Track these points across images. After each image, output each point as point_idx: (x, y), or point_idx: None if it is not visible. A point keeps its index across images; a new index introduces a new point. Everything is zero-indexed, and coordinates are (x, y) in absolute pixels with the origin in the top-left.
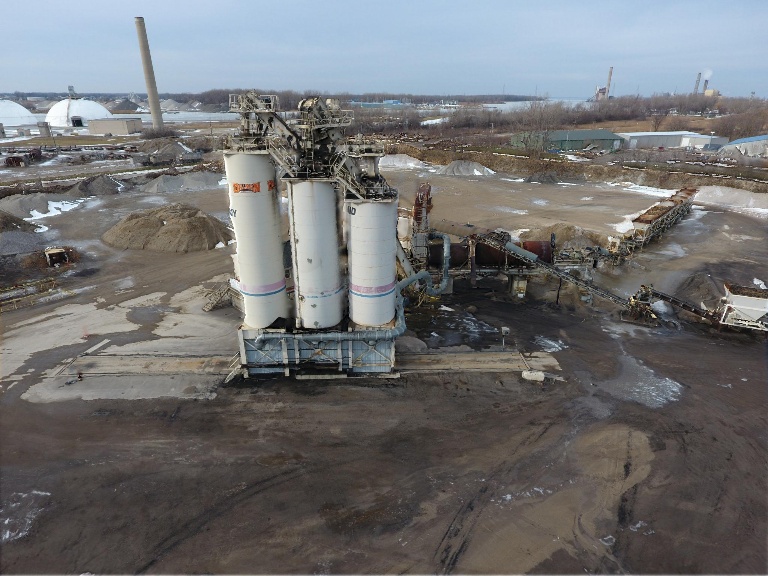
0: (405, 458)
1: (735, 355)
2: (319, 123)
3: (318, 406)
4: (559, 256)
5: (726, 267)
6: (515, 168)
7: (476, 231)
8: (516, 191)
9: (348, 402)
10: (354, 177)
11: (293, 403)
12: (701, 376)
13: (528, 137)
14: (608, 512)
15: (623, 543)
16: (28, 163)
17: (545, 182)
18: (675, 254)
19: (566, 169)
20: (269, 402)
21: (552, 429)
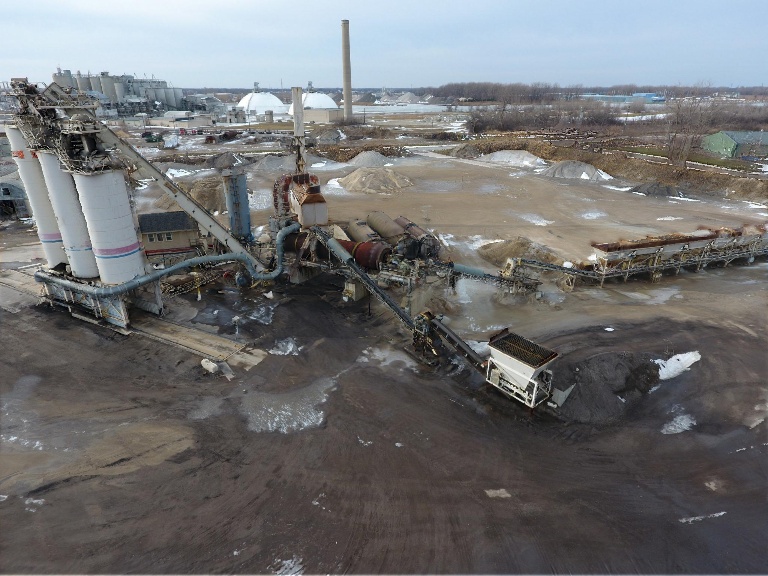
0: (21, 387)
1: (448, 419)
2: (42, 104)
3: (47, 336)
4: (385, 263)
5: (680, 328)
6: (642, 175)
7: (395, 230)
8: (590, 200)
9: (66, 340)
10: (65, 151)
11: (40, 330)
12: (359, 423)
13: (673, 137)
14: (39, 481)
15: (2, 505)
16: (218, 141)
17: (654, 194)
18: (645, 299)
19: (705, 181)
20: (32, 325)
21: (137, 409)
